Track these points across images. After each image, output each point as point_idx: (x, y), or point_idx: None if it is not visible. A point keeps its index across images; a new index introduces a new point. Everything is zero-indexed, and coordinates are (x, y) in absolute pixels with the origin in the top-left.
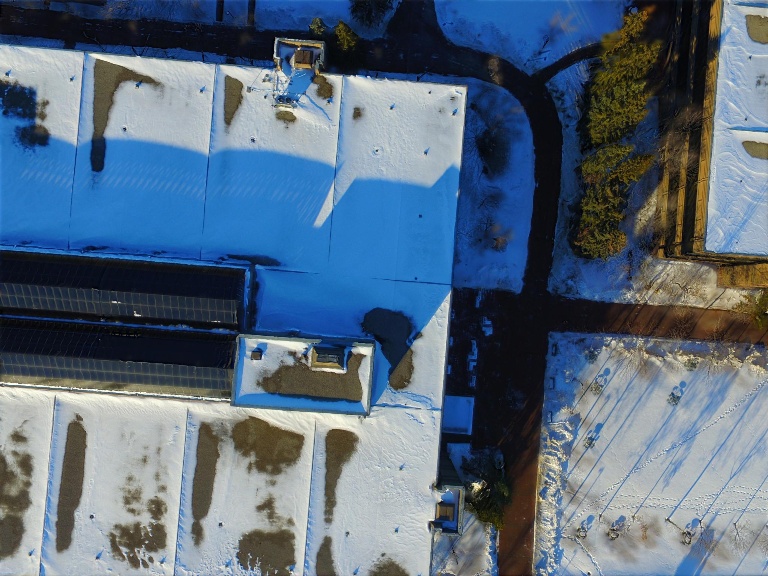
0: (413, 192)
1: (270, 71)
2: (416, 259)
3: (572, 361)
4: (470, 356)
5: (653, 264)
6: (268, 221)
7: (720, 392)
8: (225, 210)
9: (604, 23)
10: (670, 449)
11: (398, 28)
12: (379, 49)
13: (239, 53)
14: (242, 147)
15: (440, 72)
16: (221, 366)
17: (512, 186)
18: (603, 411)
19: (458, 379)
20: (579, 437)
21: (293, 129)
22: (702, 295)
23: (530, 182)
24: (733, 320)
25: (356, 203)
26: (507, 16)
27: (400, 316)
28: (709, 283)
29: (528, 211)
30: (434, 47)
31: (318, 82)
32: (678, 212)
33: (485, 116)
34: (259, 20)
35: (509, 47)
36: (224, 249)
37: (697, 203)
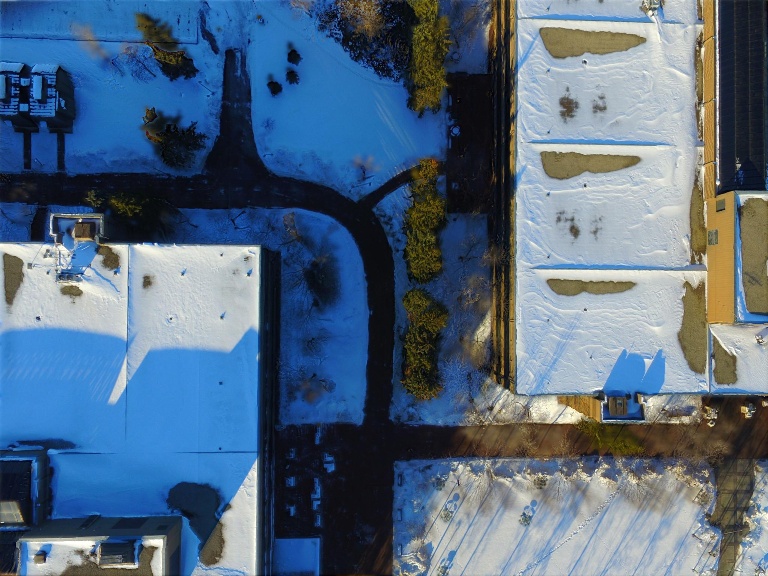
0: (212, 359)
1: (51, 246)
2: (219, 428)
3: (419, 490)
4: (313, 495)
5: (492, 386)
6: (59, 402)
7: (572, 508)
8: (12, 395)
9: (427, 144)
10: (526, 570)
11: (217, 163)
12: (198, 186)
13: (51, 201)
14: (27, 327)
15: (263, 205)
16: (3, 573)
17: (345, 316)
18: (455, 538)
19: (303, 519)
20: (432, 567)
21: (80, 304)
22: (545, 412)
23: (364, 310)
24: (579, 433)
25: (152, 376)
26: (328, 143)
27: (207, 489)
28: (550, 401)
29: (363, 340)
30: (255, 180)
31: (103, 253)
32: (501, 343)
33: (312, 247)
34: (69, 165)
35: (332, 175)
36: (13, 436)
37: (510, 342)
